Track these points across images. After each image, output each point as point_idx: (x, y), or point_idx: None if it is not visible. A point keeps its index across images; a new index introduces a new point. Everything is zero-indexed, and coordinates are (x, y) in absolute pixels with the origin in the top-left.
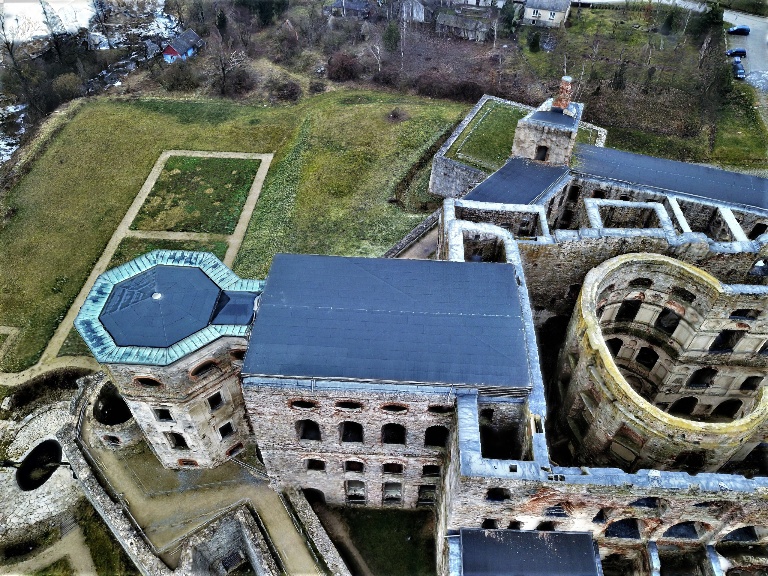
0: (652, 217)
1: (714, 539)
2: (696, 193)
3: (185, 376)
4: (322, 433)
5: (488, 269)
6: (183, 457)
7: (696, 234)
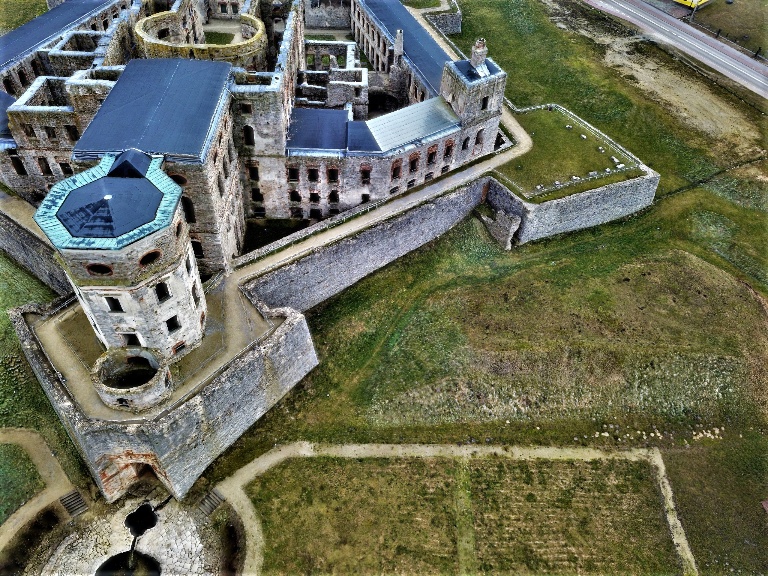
0: (79, 39)
1: None
2: (43, 38)
3: None
4: None
5: (133, 67)
6: (200, 315)
7: (124, 11)
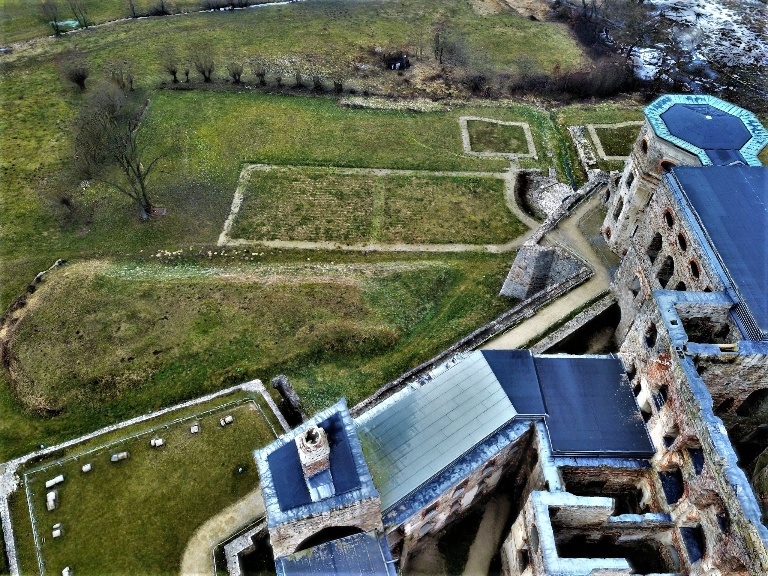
0: None
1: (696, 570)
2: None
3: (658, 159)
4: (657, 257)
5: None
6: (611, 226)
7: None
